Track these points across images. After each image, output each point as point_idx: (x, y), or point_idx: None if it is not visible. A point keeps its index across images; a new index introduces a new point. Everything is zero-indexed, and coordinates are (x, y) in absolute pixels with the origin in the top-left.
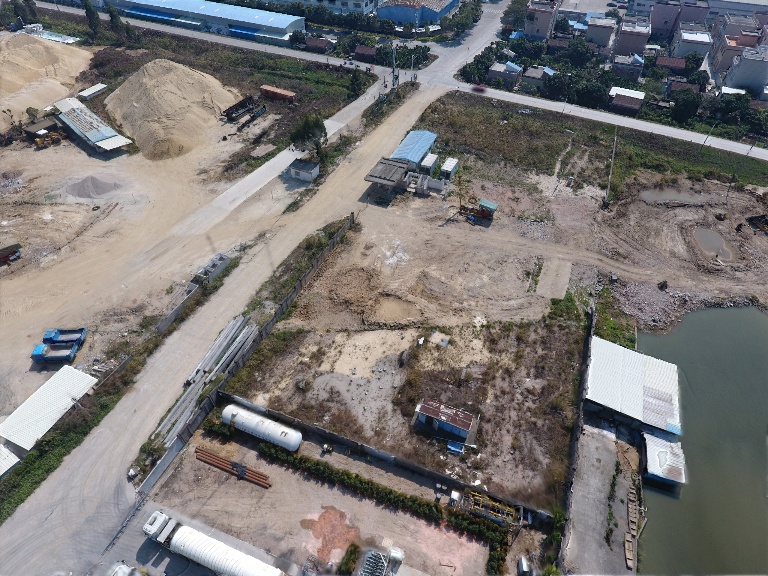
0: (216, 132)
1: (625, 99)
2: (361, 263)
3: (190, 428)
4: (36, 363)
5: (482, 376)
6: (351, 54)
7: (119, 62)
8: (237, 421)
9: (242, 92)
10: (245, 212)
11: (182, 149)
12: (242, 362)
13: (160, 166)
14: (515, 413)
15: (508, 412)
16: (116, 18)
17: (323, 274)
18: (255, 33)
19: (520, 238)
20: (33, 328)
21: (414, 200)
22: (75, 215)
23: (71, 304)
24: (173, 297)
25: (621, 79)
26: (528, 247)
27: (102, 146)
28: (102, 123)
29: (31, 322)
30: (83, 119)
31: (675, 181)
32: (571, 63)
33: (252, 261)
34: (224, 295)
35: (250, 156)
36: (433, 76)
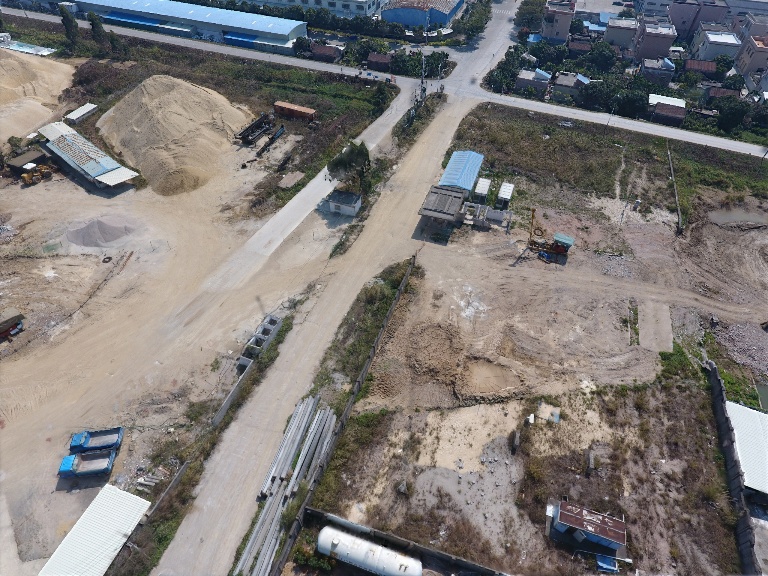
0: (232, 158)
1: (668, 108)
2: (434, 317)
3: (280, 565)
4: (64, 478)
5: (610, 460)
6: (363, 62)
7: (107, 77)
8: (340, 552)
9: (253, 109)
10: (285, 257)
11: (197, 181)
12: (326, 463)
13: (175, 203)
14: (662, 509)
15: (653, 508)
16: (98, 26)
17: (394, 334)
18: (254, 40)
19: (603, 277)
20: (53, 428)
21: (474, 234)
22: (83, 270)
23: (96, 391)
24: (221, 374)
25: (654, 85)
26: (615, 288)
27: (104, 181)
28: (100, 152)
29: (49, 419)
30: (77, 148)
31: (742, 199)
32: (596, 68)
33: (307, 321)
34: (283, 368)
35: (278, 187)
36: (459, 86)
